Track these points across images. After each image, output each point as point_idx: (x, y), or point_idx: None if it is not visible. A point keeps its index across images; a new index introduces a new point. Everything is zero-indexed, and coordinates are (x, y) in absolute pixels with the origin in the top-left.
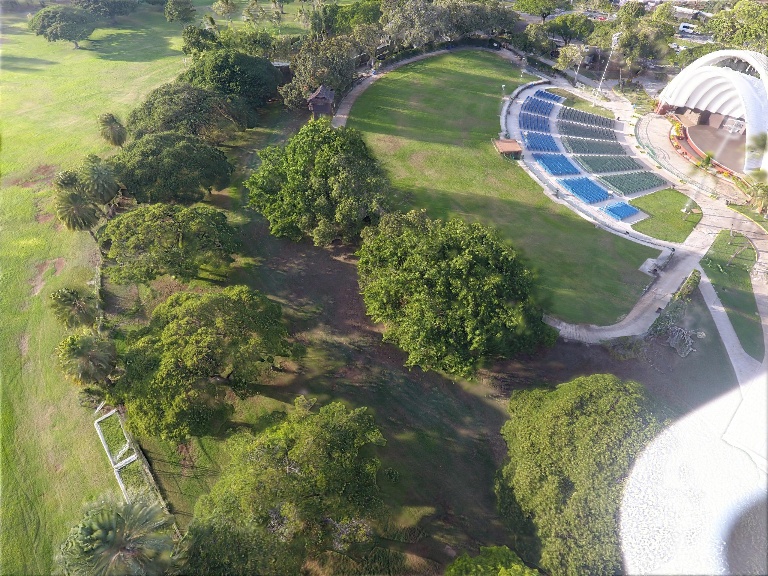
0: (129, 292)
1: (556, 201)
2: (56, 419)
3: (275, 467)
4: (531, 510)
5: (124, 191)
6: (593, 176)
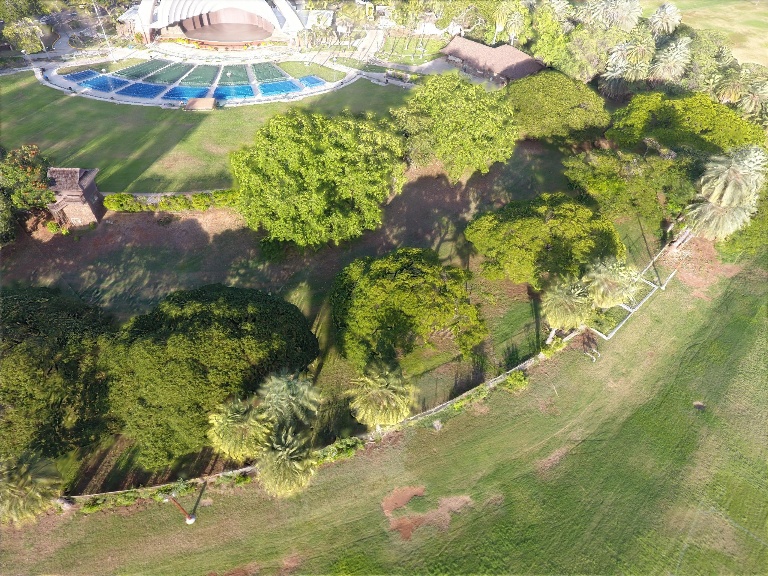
0: (446, 373)
1: (299, 99)
2: (617, 374)
3: (638, 166)
4: (584, 126)
5: (185, 478)
6: (254, 84)
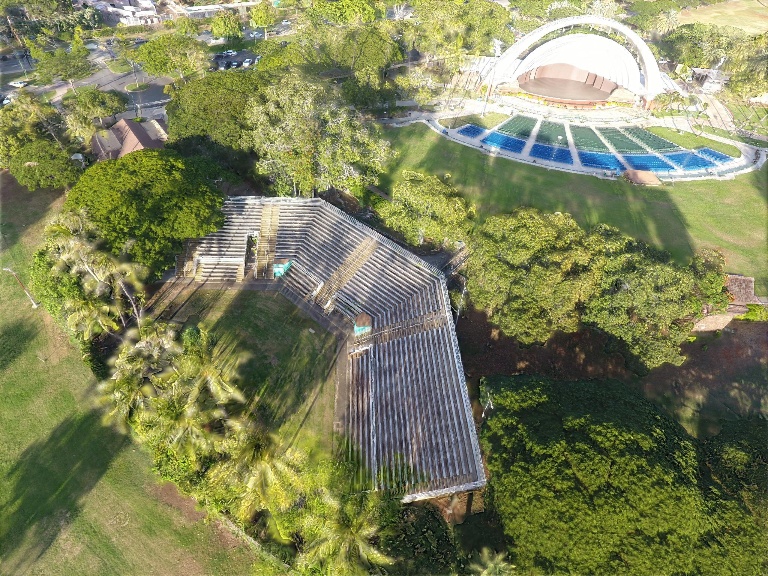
0: None
1: (732, 178)
2: None
3: None
4: None
5: None
6: (652, 153)
